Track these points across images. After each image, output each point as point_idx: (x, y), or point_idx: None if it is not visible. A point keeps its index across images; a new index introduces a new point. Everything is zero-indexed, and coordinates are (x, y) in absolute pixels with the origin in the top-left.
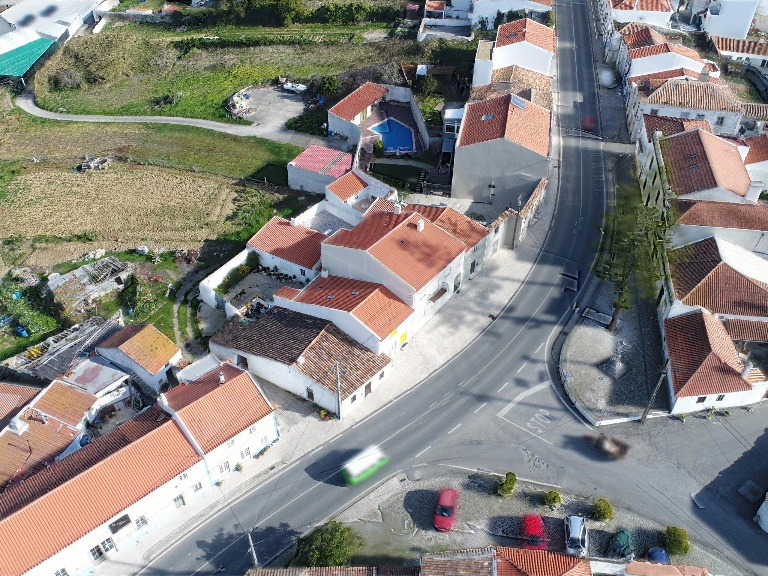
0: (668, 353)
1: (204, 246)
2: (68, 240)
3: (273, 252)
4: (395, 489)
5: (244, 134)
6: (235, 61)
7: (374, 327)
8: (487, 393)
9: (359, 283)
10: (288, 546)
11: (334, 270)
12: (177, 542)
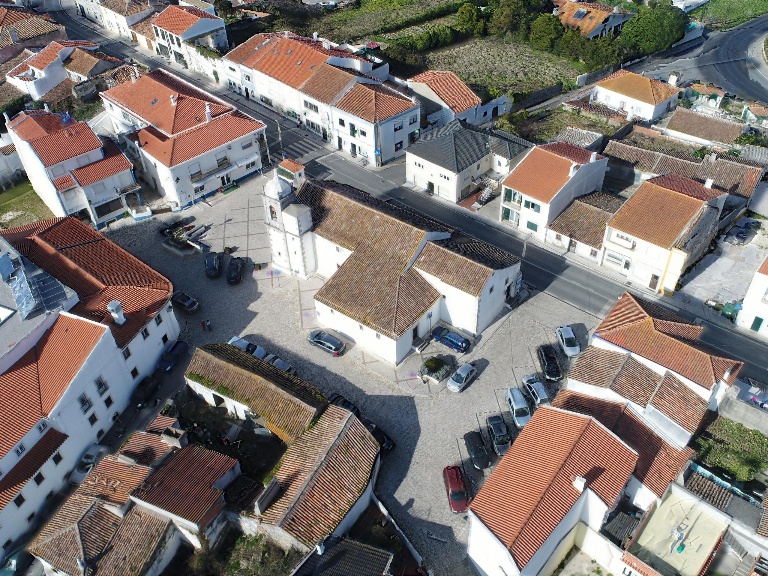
0: None
1: None
2: None
3: None
4: None
5: None
6: (418, 8)
7: None
8: None
9: None
10: None
11: None
12: None
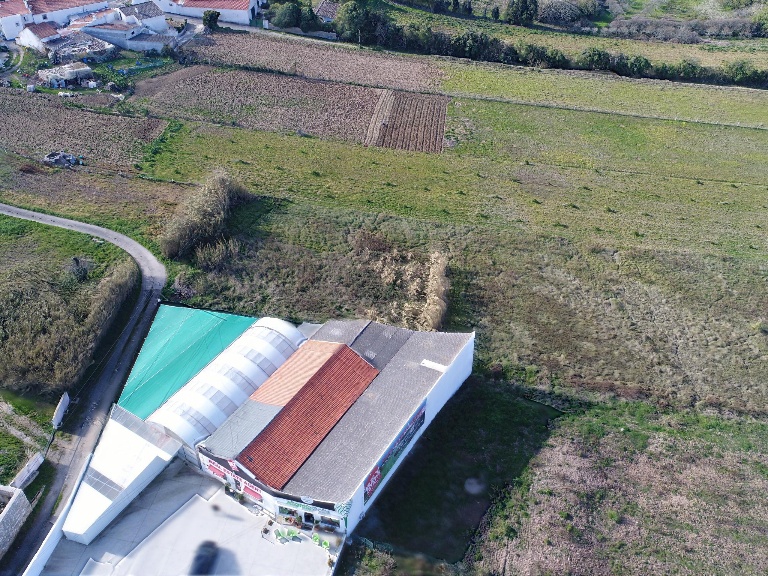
0: None
1: None
2: None
3: None
4: None
5: None
6: None
7: None
8: None
9: None
10: None
11: None
12: None
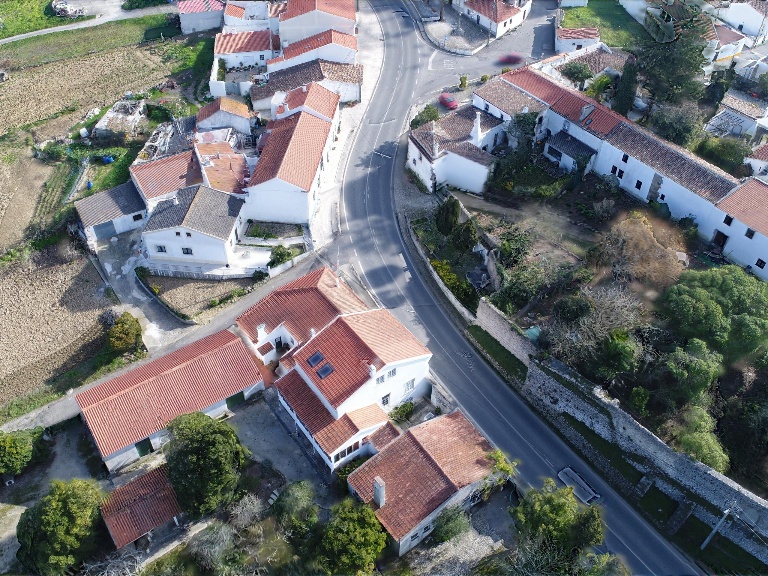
0: (479, 12)
1: (170, 79)
2: (54, 117)
3: (237, 51)
4: (418, 110)
5: (98, 24)
6: None
7: (349, 47)
8: (415, 65)
9: (316, 36)
10: (397, 147)
11: (291, 39)
12: (346, 171)
